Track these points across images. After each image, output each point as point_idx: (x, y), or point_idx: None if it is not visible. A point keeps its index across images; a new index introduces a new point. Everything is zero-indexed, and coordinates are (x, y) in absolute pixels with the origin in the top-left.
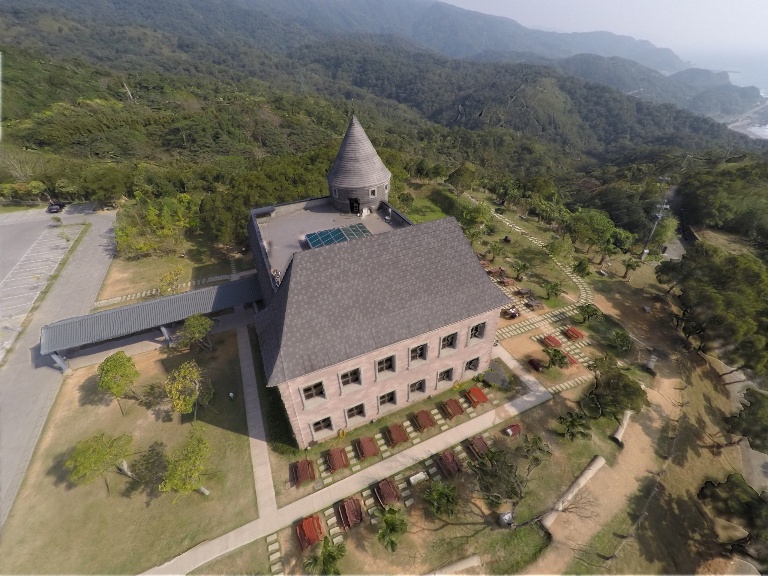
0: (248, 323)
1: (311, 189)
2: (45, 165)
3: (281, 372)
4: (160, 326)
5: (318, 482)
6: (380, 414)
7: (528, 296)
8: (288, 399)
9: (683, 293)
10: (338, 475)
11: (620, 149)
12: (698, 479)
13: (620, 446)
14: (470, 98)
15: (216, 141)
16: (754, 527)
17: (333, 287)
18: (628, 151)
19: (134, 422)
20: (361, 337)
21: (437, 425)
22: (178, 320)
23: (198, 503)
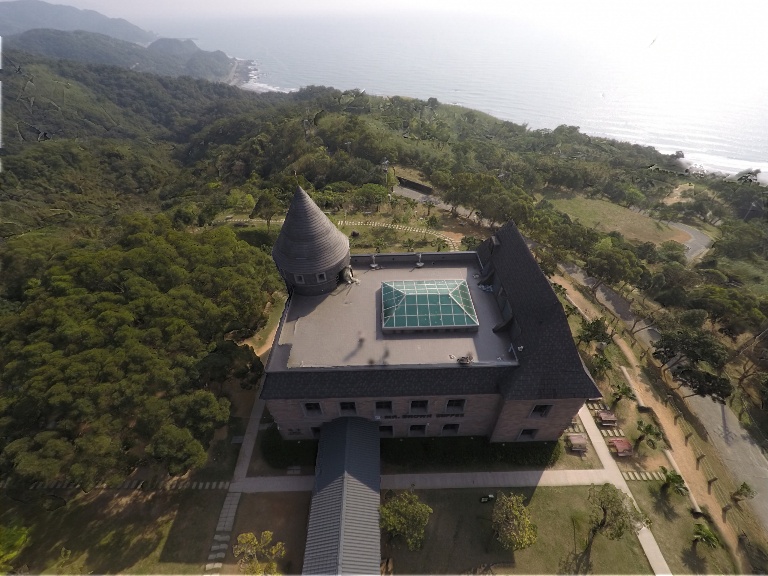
0: None
1: (209, 308)
2: None
3: None
4: None
5: (582, 436)
6: None
7: None
8: None
9: None
10: None
11: (201, 127)
12: None
13: None
14: None
15: None
16: None
17: None
18: (209, 127)
19: None
20: None
21: None
22: None
23: (602, 540)
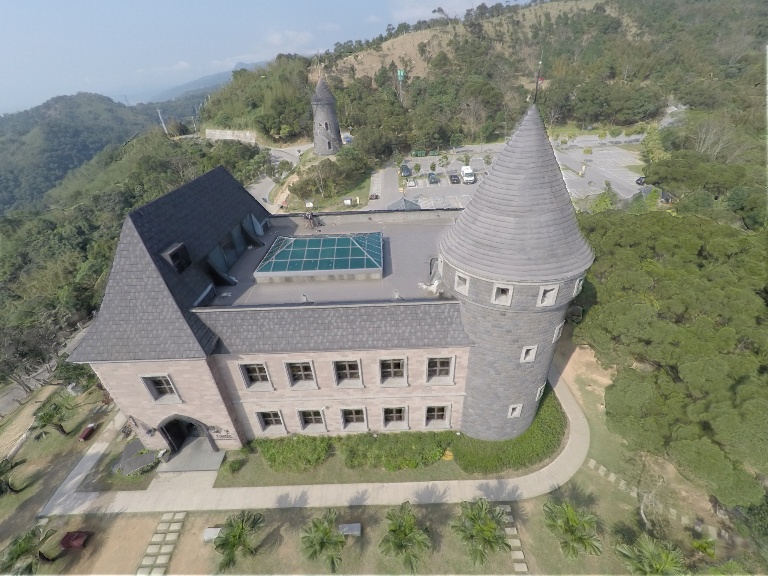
0: None
1: None
2: (746, 151)
3: None
4: None
5: None
6: None
7: None
8: None
9: None
10: None
11: None
12: None
13: None
14: None
15: None
16: None
17: None
18: None
19: None
20: None
21: None
22: None
23: None
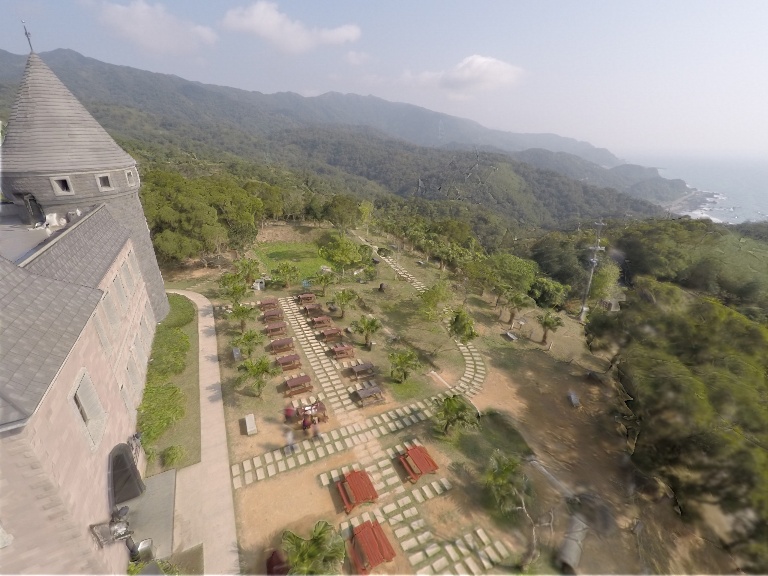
0: None
1: None
2: None
3: None
4: None
5: None
6: None
7: (366, 377)
8: None
9: None
10: None
11: (571, 221)
12: None
13: None
14: (430, 175)
15: None
16: None
17: None
18: (578, 222)
19: None
20: None
21: None
22: None
23: None
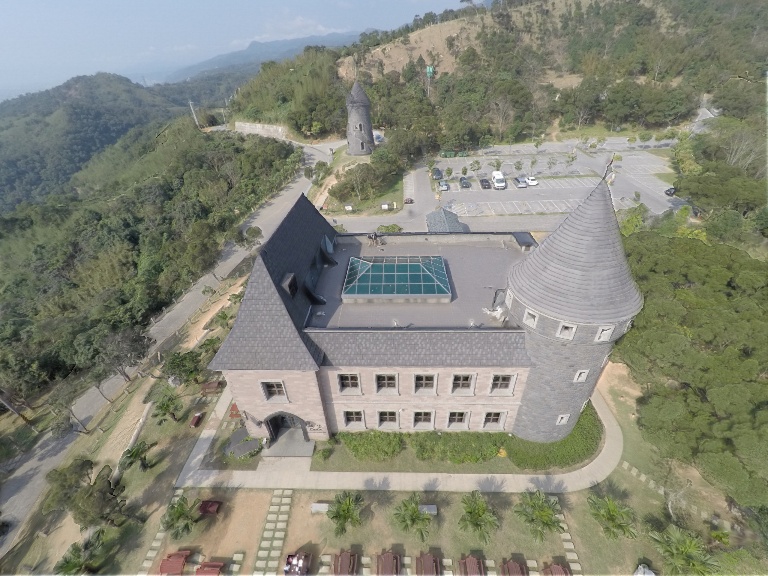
0: None
1: (669, 301)
2: None
3: None
4: None
5: None
6: None
7: None
8: None
9: None
10: None
11: None
12: None
13: None
14: None
15: None
16: None
17: None
18: None
19: None
20: None
21: None
22: None
23: None
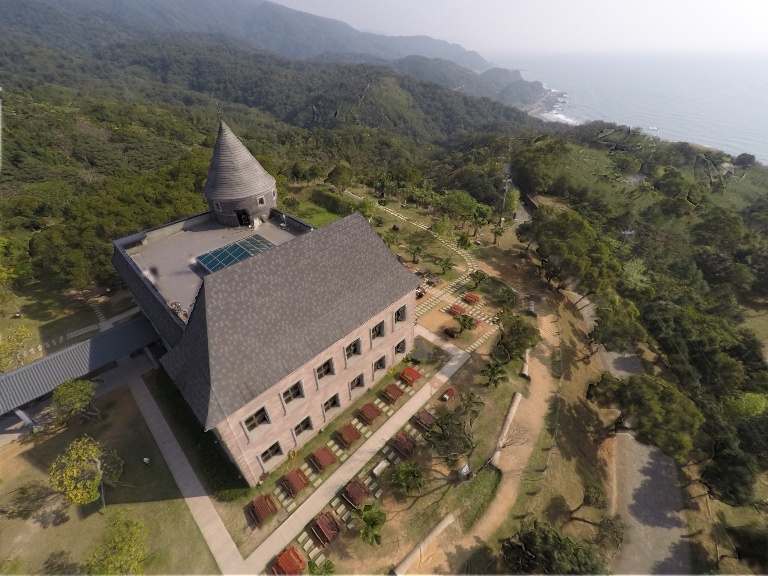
0: (141, 373)
1: (182, 207)
2: None
3: (218, 410)
4: (14, 410)
5: (281, 513)
6: (327, 421)
7: (427, 275)
8: (230, 438)
9: (539, 247)
10: (301, 497)
11: (460, 137)
12: (582, 386)
13: (528, 379)
14: (322, 99)
15: (19, 166)
16: (625, 406)
17: (256, 304)
18: (466, 138)
19: (8, 542)
20: (296, 349)
21: (383, 413)
22: (41, 395)
23: None
